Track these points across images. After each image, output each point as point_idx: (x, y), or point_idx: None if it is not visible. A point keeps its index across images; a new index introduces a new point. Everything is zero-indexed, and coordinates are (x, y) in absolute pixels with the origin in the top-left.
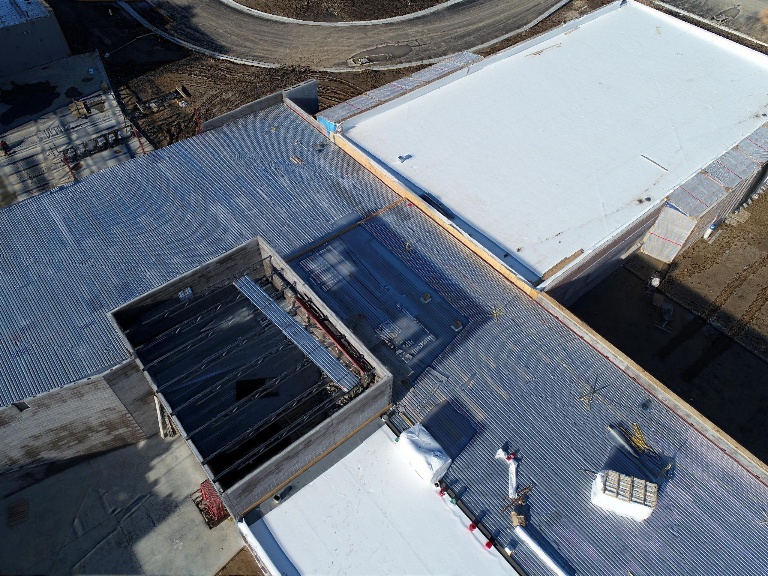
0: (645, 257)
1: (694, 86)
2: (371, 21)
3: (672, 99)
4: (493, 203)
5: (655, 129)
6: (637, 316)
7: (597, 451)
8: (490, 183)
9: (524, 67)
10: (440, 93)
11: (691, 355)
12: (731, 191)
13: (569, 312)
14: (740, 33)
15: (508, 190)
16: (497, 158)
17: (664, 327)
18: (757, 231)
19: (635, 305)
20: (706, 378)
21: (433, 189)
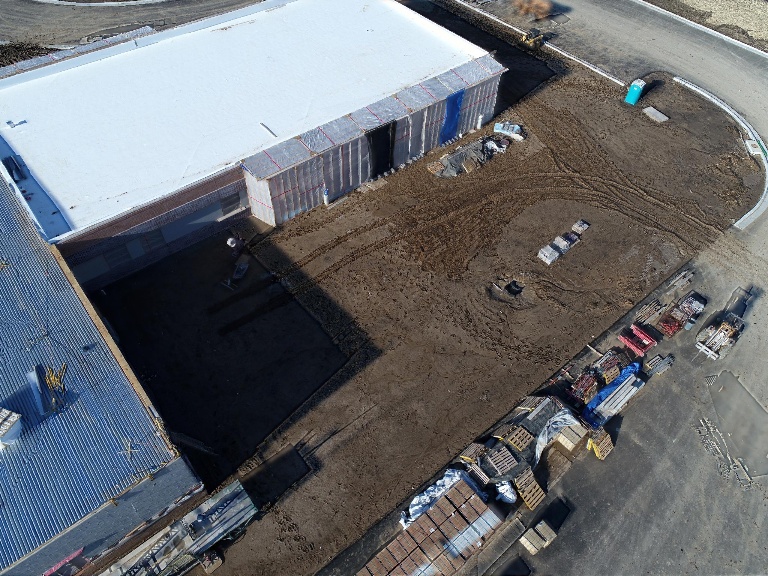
0: (255, 221)
1: (362, 60)
2: (129, 2)
3: (331, 72)
4: (77, 165)
5: (293, 99)
6: (211, 275)
7: (7, 387)
8: (88, 147)
9: (202, 41)
10: (98, 64)
11: (241, 311)
12: (316, 155)
13: (64, 263)
14: (490, 15)
15: (101, 153)
16: (112, 124)
17: (229, 285)
18: (383, 198)
19: (216, 265)
20: (243, 332)
21: (26, 152)
